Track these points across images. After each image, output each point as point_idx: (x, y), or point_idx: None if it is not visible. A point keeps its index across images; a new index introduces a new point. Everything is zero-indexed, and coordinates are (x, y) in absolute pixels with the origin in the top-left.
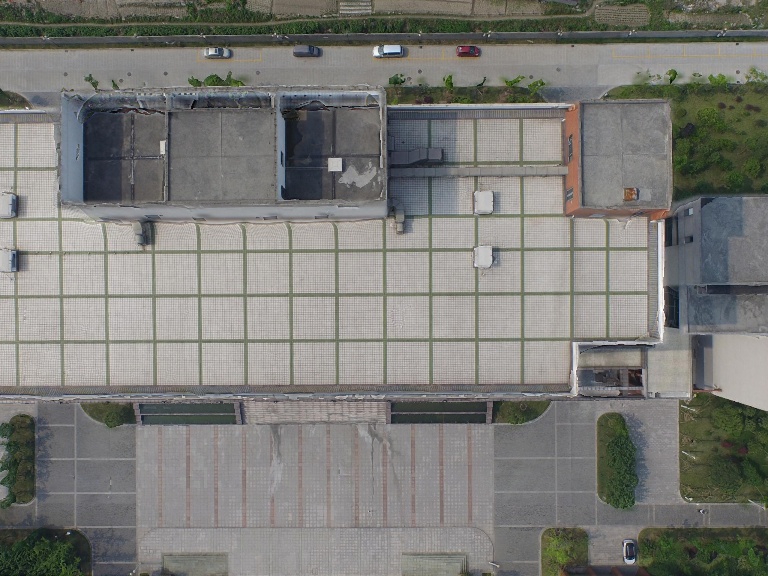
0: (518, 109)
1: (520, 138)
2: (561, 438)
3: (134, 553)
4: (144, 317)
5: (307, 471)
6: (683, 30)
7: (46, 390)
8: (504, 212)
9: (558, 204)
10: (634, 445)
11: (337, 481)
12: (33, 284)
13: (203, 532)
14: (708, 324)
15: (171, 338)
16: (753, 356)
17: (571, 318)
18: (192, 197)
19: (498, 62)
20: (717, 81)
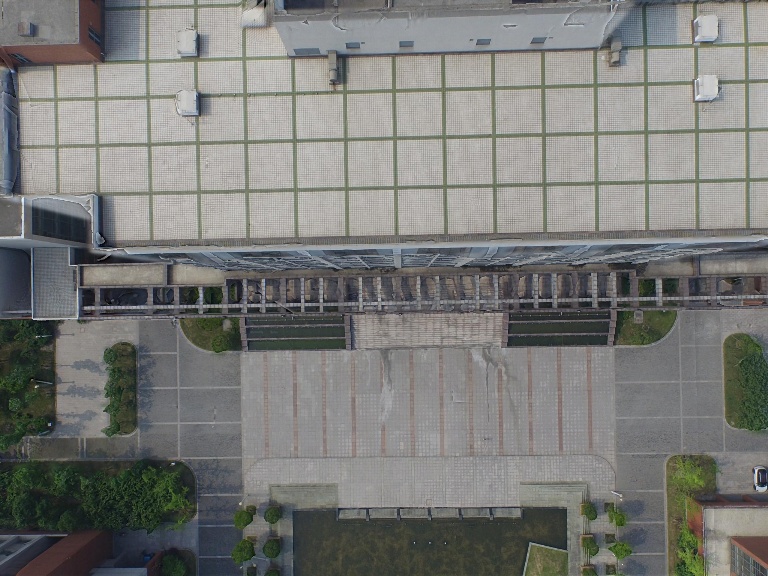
0: None
1: None
2: (686, 361)
3: (240, 485)
4: (335, 163)
5: (419, 398)
6: None
7: (231, 242)
8: (726, 41)
9: None
10: None
11: (450, 408)
12: (216, 129)
13: (311, 462)
14: None
15: (364, 185)
16: None
17: None
18: (417, 3)
19: None
20: None
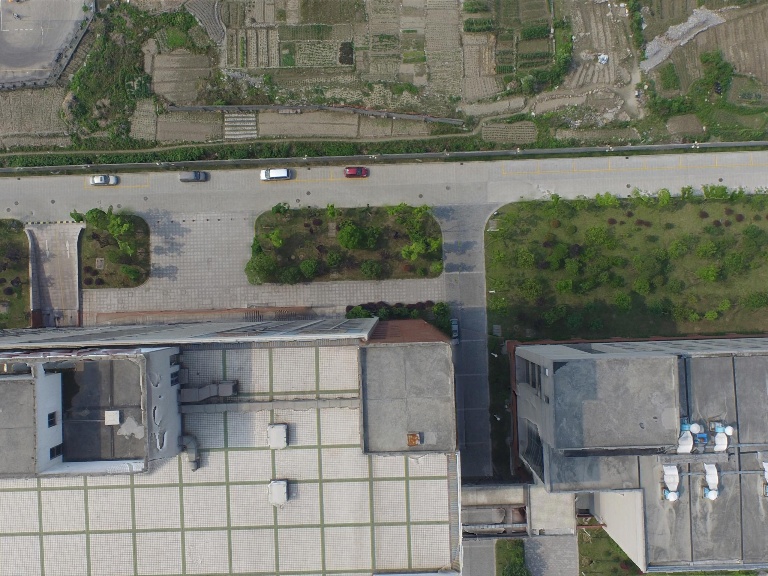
0: (310, 341)
1: (316, 367)
2: None
3: None
4: None
5: None
6: (571, 147)
7: None
8: (301, 444)
9: (355, 434)
10: (533, 567)
11: None
12: None
13: None
14: (571, 482)
15: None
16: (625, 504)
17: (372, 549)
18: None
19: (387, 182)
20: (602, 202)
